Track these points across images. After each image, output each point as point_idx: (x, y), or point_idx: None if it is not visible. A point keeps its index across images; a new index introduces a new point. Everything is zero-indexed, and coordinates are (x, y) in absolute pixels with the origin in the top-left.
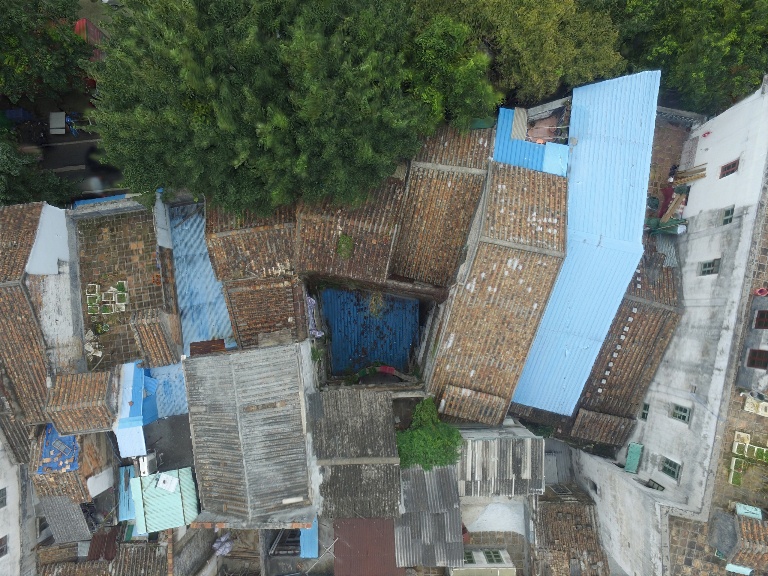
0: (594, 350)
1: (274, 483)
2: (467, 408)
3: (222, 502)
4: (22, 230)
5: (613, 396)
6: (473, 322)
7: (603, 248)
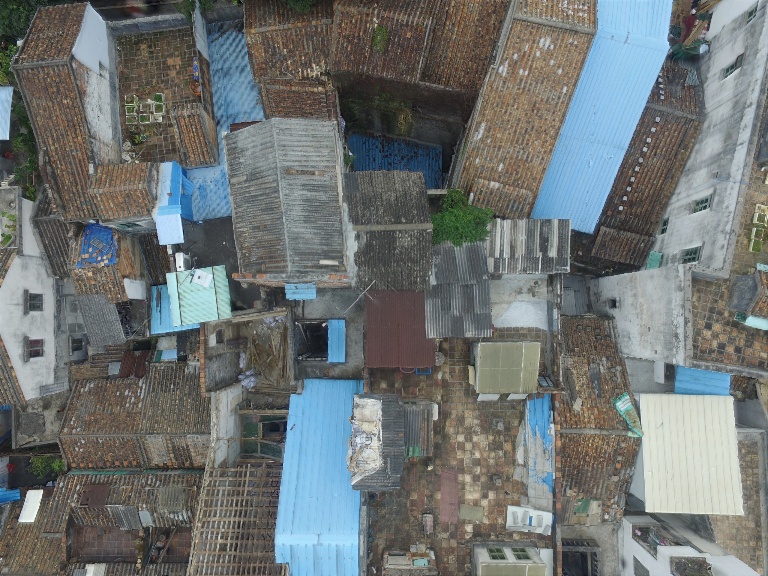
0: (617, 160)
1: (312, 244)
2: (495, 202)
3: (261, 263)
4: (67, 23)
5: (633, 215)
6: (504, 110)
7: (630, 45)
